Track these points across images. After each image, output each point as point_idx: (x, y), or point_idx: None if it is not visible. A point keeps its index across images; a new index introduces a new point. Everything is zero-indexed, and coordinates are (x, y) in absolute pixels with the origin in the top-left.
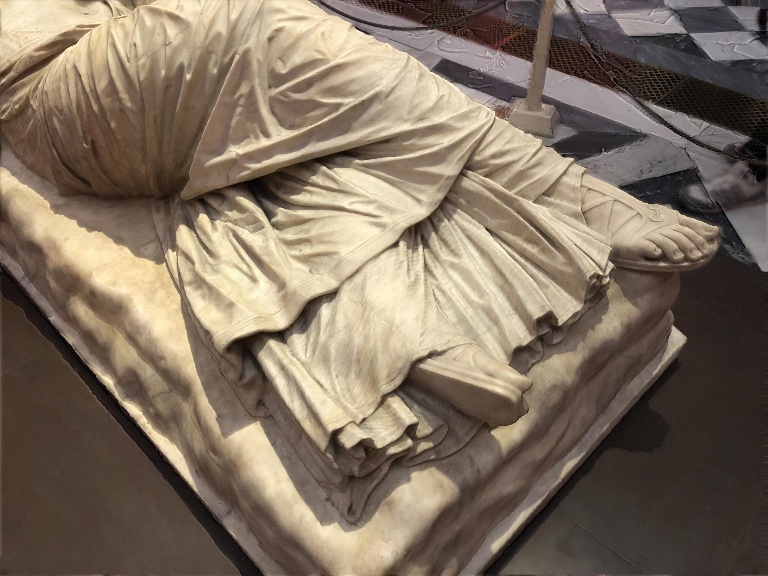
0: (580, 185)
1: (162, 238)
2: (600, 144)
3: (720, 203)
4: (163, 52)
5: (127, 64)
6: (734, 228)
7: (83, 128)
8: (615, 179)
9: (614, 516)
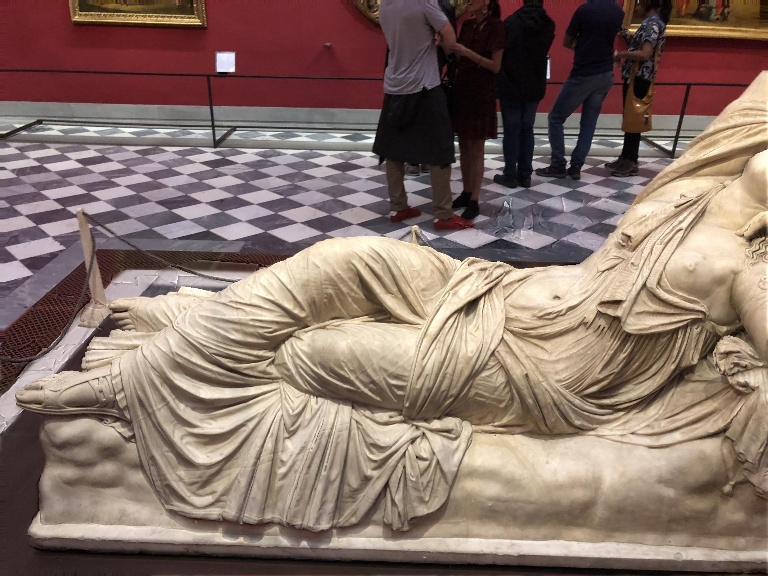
0: None
1: None
2: None
3: None
4: None
5: None
6: None
7: None
8: None
9: None
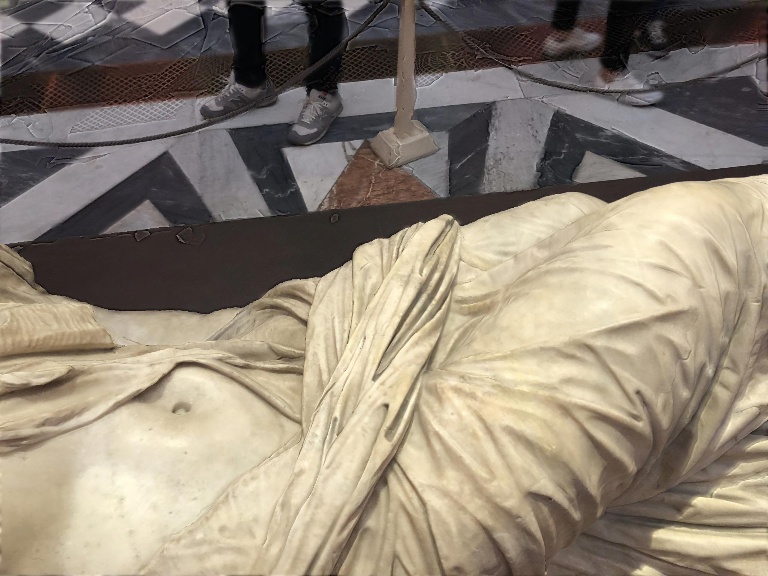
0: None
1: (594, 569)
2: (479, 131)
3: (615, 128)
4: (679, 371)
5: (640, 425)
6: (639, 141)
7: (546, 557)
8: (530, 155)
9: None
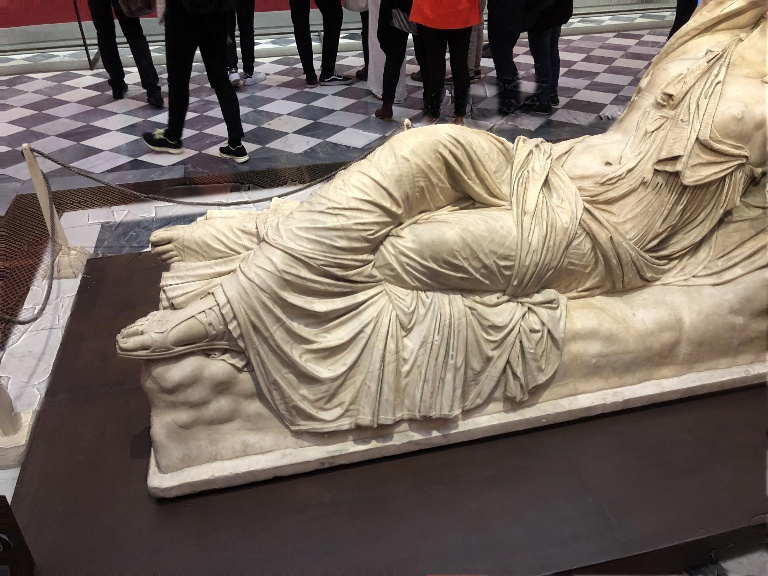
0: (209, 292)
1: None
2: None
3: None
4: None
5: None
6: None
7: None
8: None
9: (132, 397)
